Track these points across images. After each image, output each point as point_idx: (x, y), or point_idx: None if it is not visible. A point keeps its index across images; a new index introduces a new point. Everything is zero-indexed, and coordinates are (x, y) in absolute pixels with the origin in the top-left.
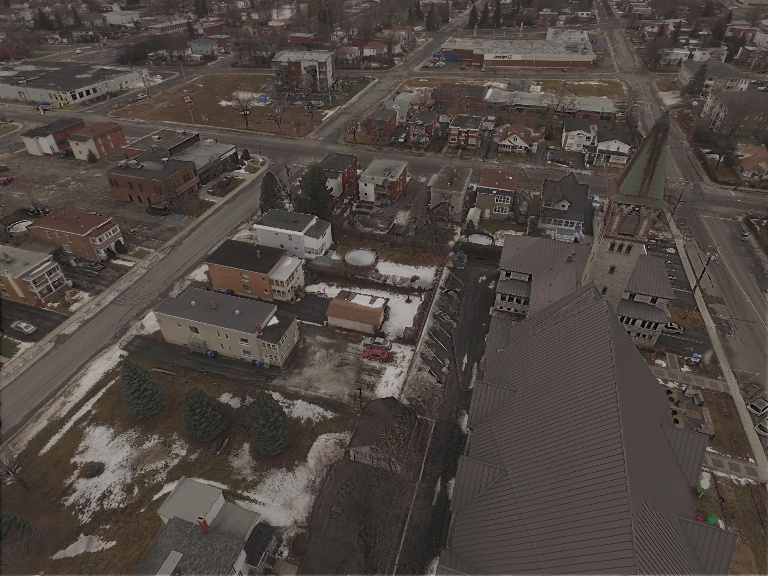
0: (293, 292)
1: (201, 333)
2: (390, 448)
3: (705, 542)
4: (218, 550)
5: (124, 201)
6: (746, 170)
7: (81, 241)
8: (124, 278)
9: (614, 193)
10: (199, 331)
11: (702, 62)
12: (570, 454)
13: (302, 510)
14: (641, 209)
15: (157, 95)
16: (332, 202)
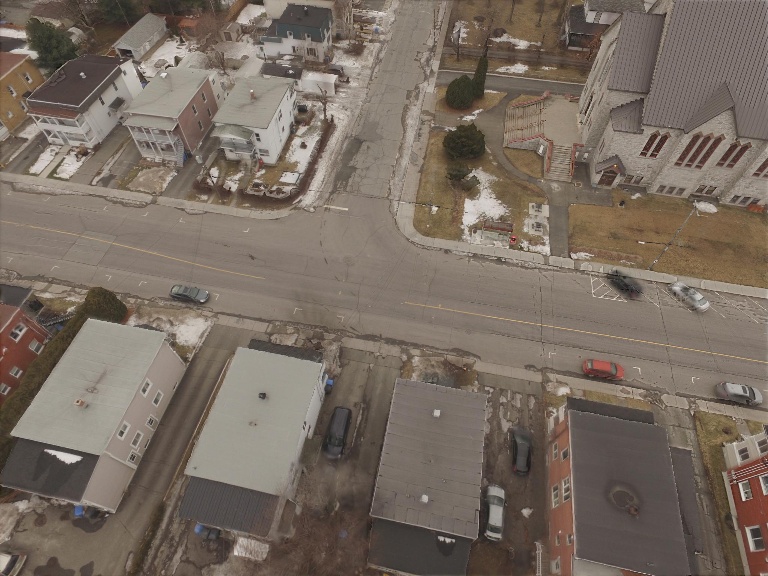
0: None
1: None
2: None
3: None
4: (638, 3)
5: None
6: None
7: None
8: None
9: None
10: None
11: None
12: None
13: None
14: None
15: None
16: None
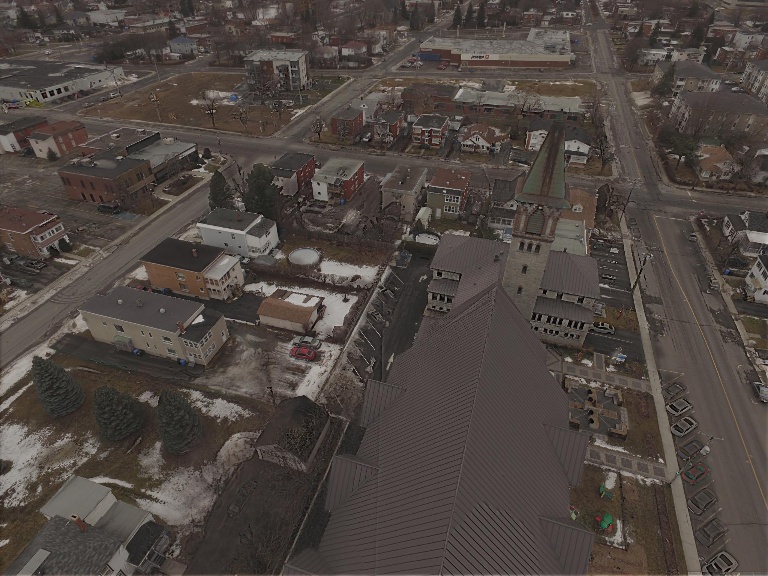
0: (230, 291)
1: (126, 331)
2: (293, 447)
3: (564, 542)
4: (91, 549)
5: (77, 199)
6: (704, 170)
7: (22, 239)
8: (65, 276)
9: (518, 192)
10: (124, 329)
11: (675, 62)
12: (427, 453)
13: (202, 509)
14: (544, 208)
15: (129, 94)
16: (282, 201)
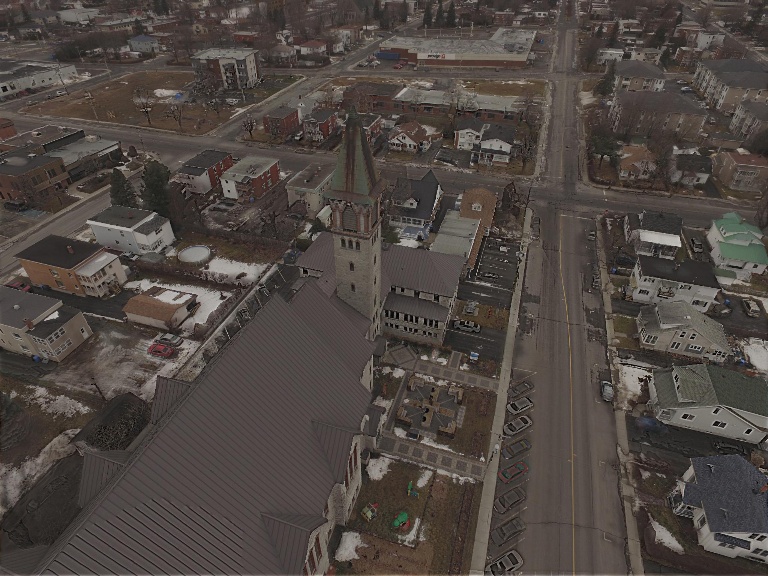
0: (107, 288)
1: None
2: (104, 444)
3: (283, 539)
4: None
5: None
6: (622, 170)
7: None
8: None
9: None
10: None
11: (622, 62)
12: None
13: (5, 505)
14: (352, 205)
15: (77, 92)
16: (183, 199)
